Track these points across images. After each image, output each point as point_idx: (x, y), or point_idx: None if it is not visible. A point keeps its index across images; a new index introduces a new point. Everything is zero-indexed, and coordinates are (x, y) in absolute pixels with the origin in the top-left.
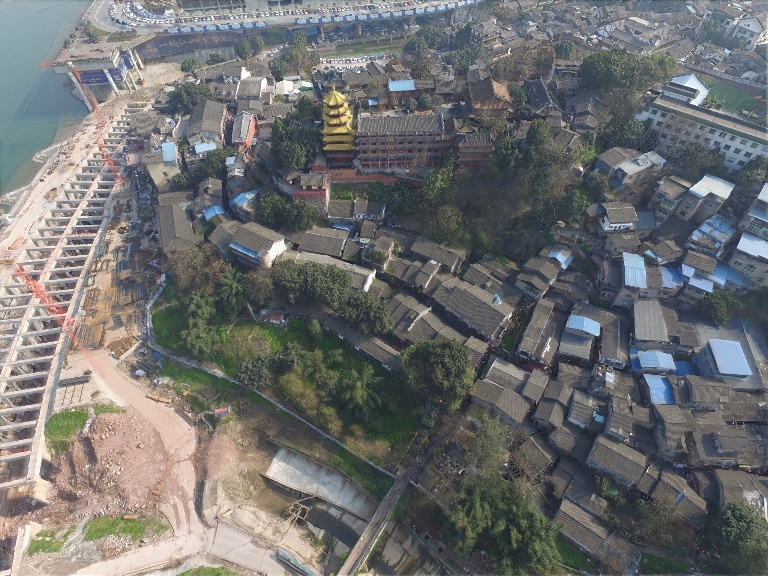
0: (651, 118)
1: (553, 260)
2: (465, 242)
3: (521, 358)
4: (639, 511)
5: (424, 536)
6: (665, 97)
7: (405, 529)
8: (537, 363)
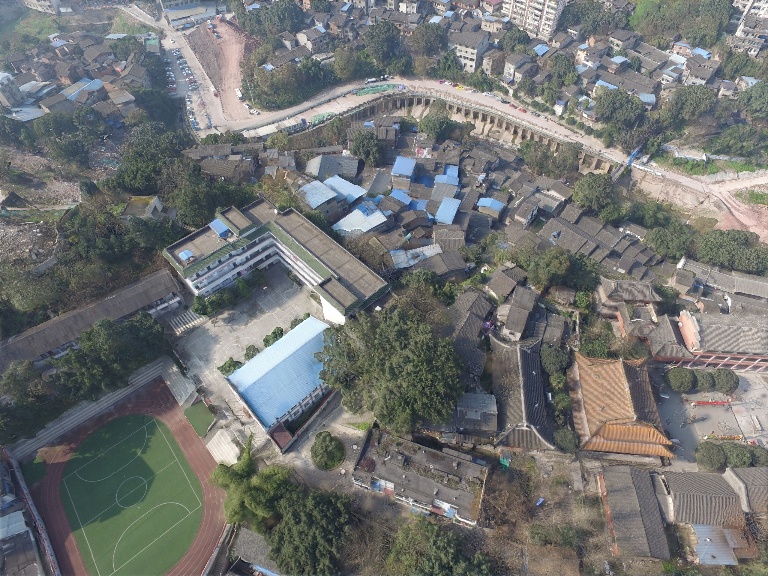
0: None
1: None
2: None
3: None
4: None
5: None
6: None
7: None
8: None
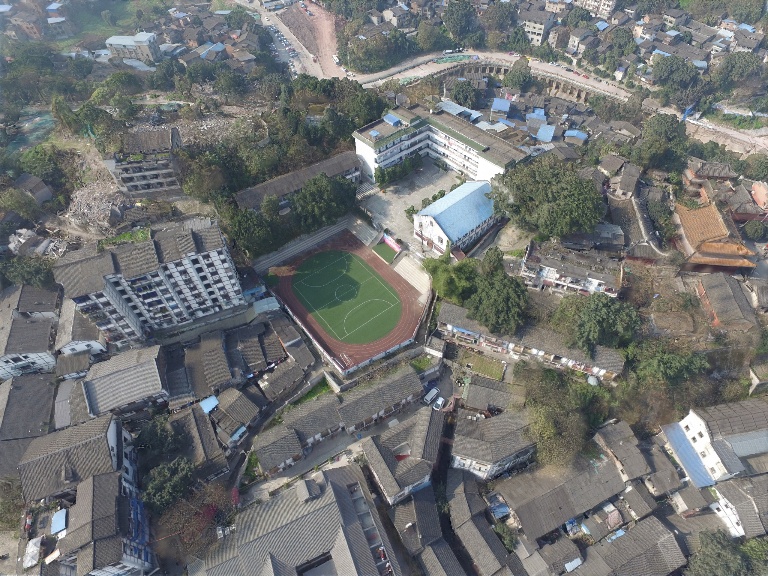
0: None
1: None
2: None
3: None
4: None
5: None
6: None
7: None
8: None
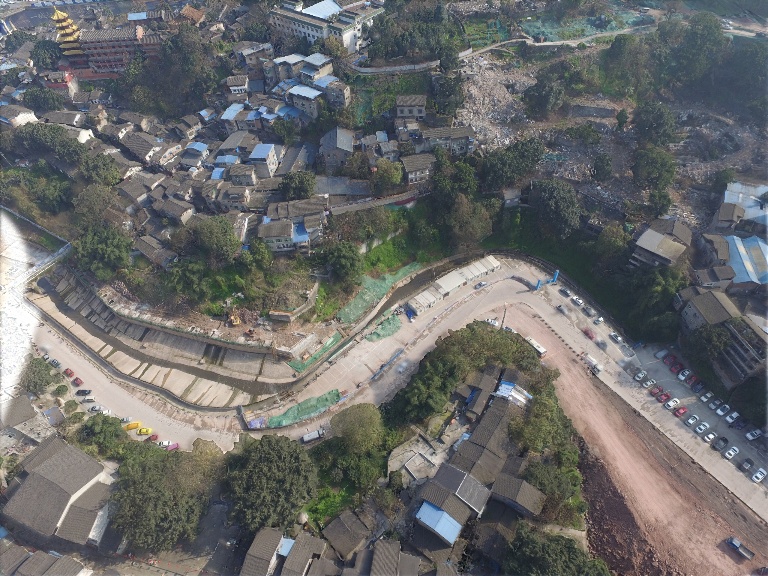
0: (275, 22)
1: (200, 115)
2: (154, 111)
3: (162, 172)
4: (179, 232)
5: (76, 270)
6: (284, 8)
7: (71, 271)
8: (168, 172)
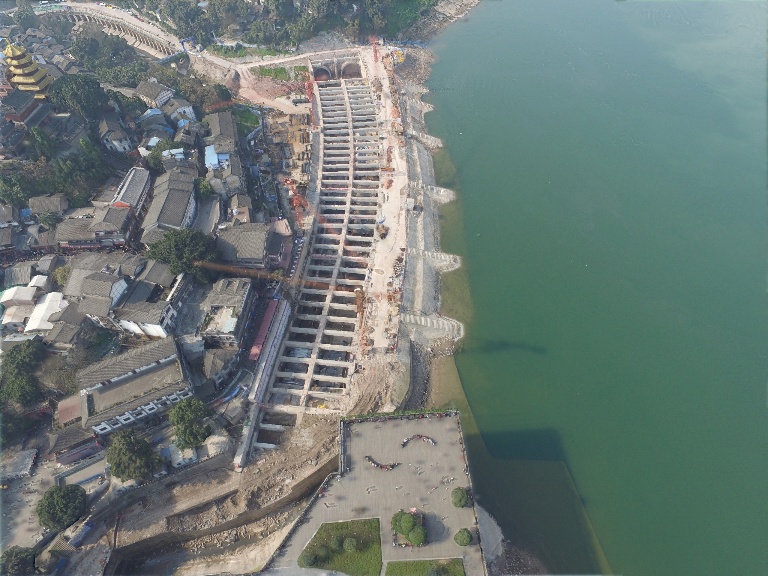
0: None
1: None
2: None
3: None
4: None
5: None
6: None
7: None
8: None
